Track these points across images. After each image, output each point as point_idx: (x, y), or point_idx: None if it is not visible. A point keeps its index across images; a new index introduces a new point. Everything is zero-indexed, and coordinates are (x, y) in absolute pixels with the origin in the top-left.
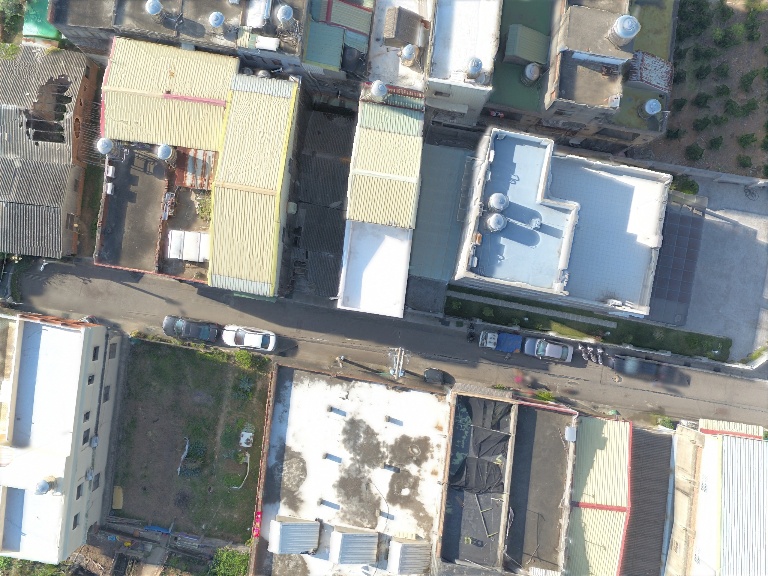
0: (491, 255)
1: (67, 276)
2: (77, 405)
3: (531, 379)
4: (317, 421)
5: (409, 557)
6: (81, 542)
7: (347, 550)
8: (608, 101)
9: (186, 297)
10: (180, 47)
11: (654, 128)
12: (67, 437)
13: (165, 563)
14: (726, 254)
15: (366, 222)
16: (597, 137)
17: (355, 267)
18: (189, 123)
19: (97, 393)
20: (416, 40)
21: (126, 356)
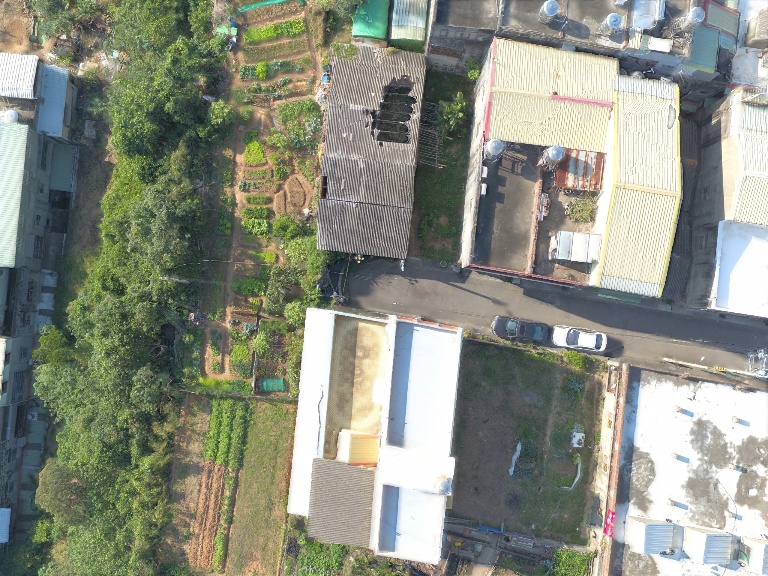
0: None
1: (393, 276)
2: None
3: None
4: (665, 421)
5: None
6: None
7: (709, 550)
8: None
9: (512, 297)
10: (560, 48)
11: None
12: (445, 437)
13: (496, 563)
14: None
15: (751, 223)
16: None
17: (723, 268)
18: (579, 124)
19: None
20: None
21: None
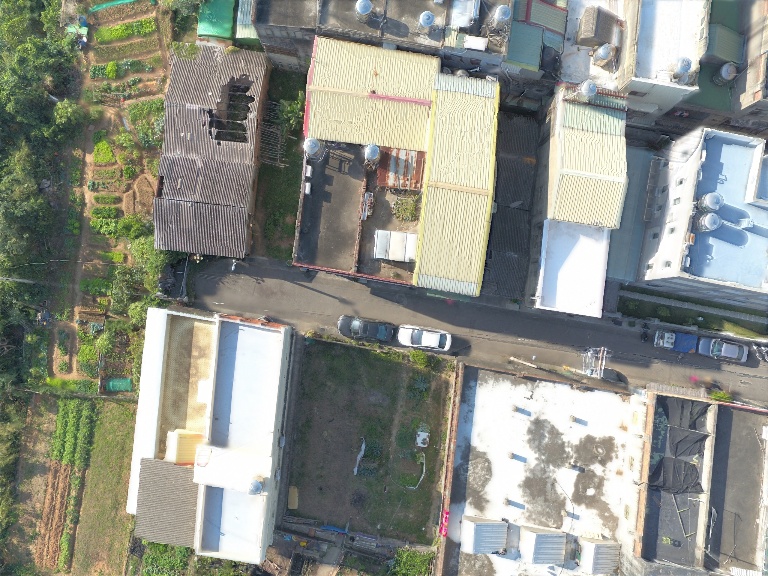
0: (700, 255)
1: (240, 276)
2: (276, 405)
3: (704, 379)
4: (502, 421)
5: (601, 557)
6: (268, 542)
7: (540, 550)
8: None
9: (359, 297)
10: (381, 47)
11: None
12: (267, 437)
13: (341, 563)
14: None
15: None
16: None
17: (550, 267)
18: (396, 123)
19: (283, 393)
20: (612, 39)
21: (300, 356)
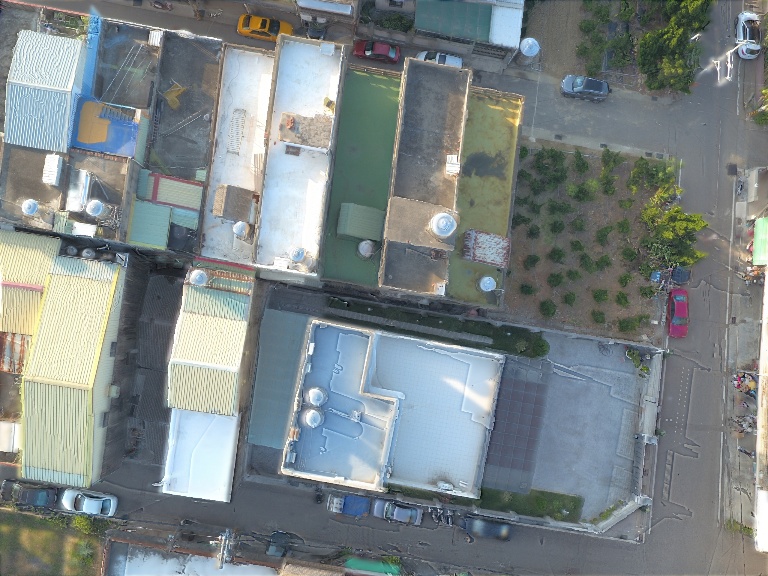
0: (313, 447)
1: None
2: None
3: (382, 540)
4: None
5: None
6: None
7: None
8: (433, 289)
9: None
10: None
11: (493, 301)
12: None
13: None
14: (580, 411)
15: None
16: (443, 302)
17: (184, 448)
18: (3, 310)
19: None
20: (247, 216)
21: None
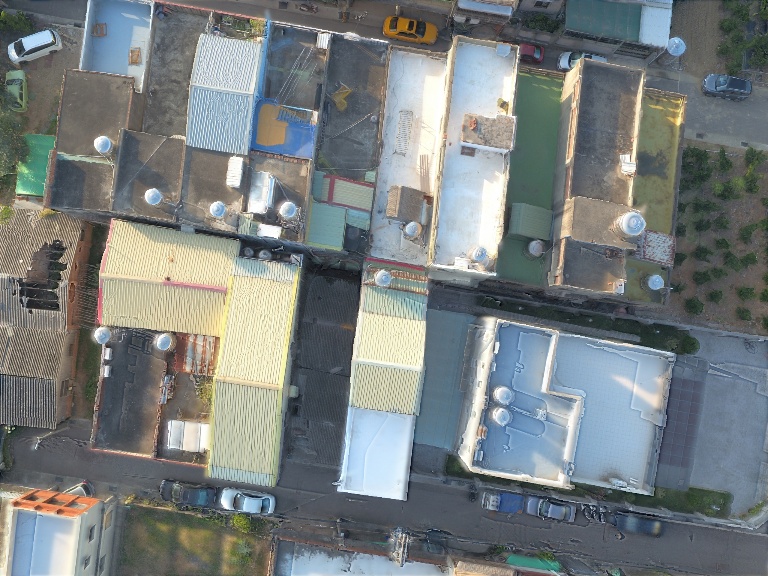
0: (496, 445)
1: (61, 438)
2: None
3: (534, 538)
4: None
5: None
6: None
7: None
8: (612, 287)
9: None
10: (179, 229)
11: (656, 300)
12: None
13: None
14: (727, 408)
15: None
16: (599, 300)
17: (358, 447)
18: (189, 312)
19: (93, 570)
20: (418, 217)
21: (122, 521)
